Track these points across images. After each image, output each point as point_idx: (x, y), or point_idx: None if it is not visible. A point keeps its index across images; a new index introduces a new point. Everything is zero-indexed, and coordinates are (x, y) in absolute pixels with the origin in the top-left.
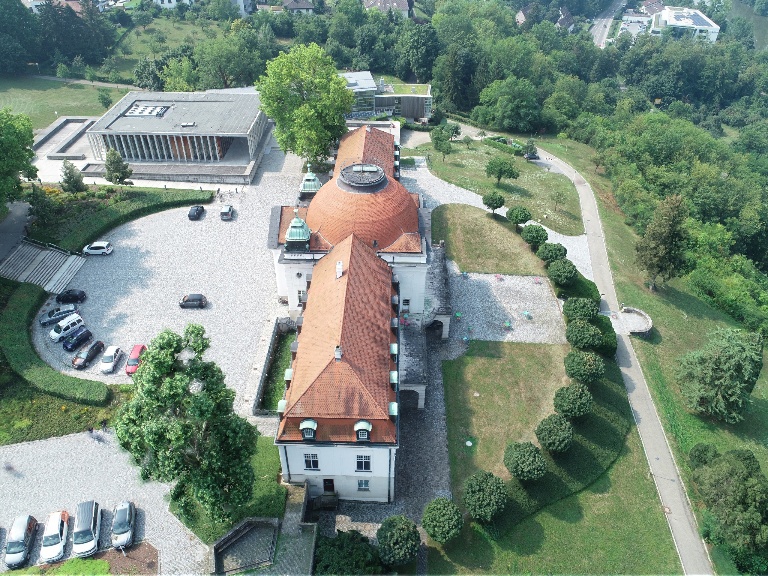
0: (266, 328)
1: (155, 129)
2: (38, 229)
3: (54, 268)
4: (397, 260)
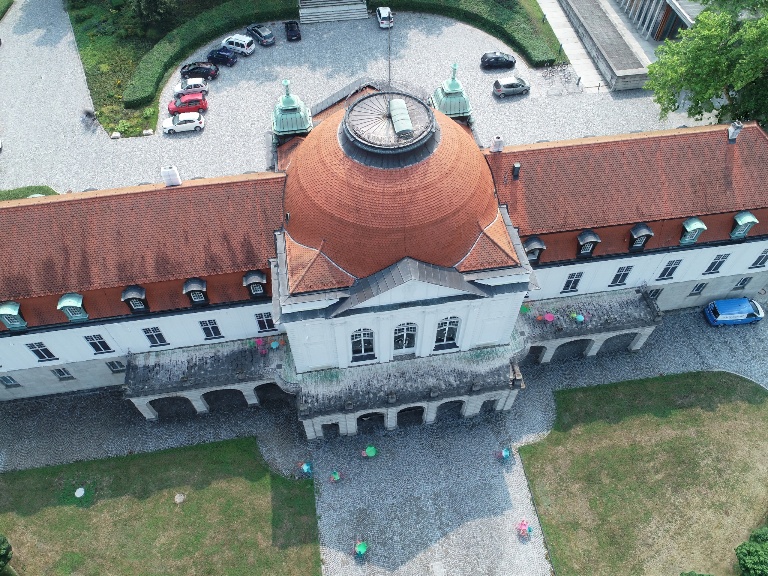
0: None
1: None
2: None
3: (336, 1)
4: None
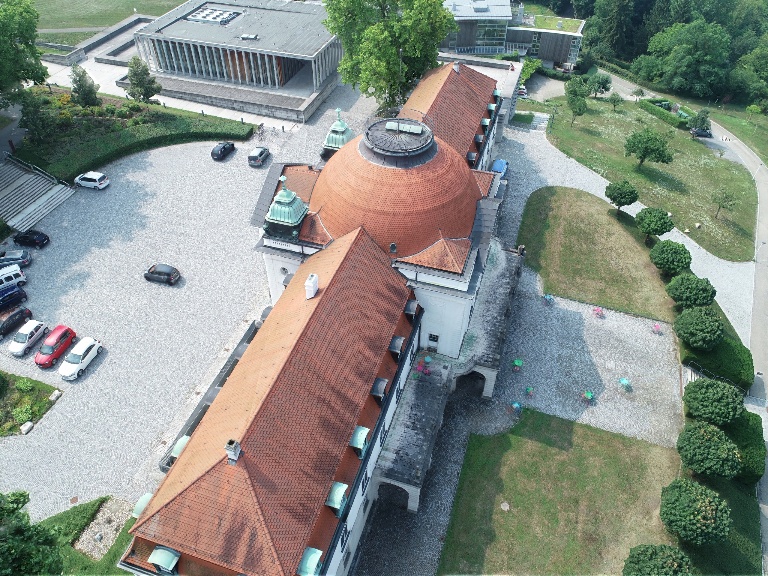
0: (238, 332)
1: (210, 38)
2: (30, 146)
3: (31, 198)
4: (422, 278)
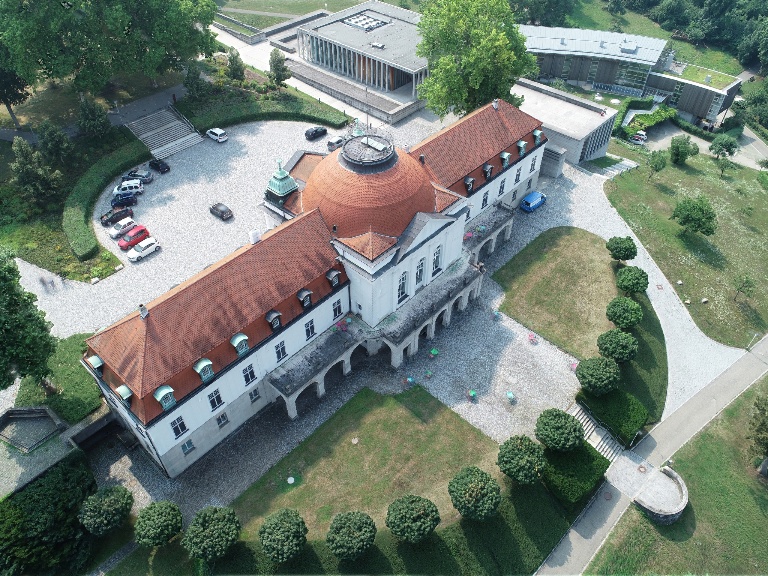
0: None
1: (348, 41)
2: (187, 101)
3: (173, 137)
4: (348, 257)
